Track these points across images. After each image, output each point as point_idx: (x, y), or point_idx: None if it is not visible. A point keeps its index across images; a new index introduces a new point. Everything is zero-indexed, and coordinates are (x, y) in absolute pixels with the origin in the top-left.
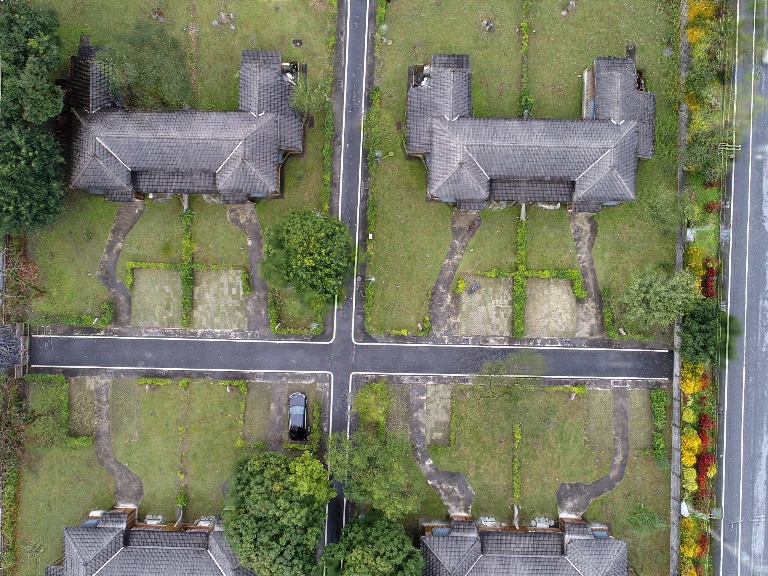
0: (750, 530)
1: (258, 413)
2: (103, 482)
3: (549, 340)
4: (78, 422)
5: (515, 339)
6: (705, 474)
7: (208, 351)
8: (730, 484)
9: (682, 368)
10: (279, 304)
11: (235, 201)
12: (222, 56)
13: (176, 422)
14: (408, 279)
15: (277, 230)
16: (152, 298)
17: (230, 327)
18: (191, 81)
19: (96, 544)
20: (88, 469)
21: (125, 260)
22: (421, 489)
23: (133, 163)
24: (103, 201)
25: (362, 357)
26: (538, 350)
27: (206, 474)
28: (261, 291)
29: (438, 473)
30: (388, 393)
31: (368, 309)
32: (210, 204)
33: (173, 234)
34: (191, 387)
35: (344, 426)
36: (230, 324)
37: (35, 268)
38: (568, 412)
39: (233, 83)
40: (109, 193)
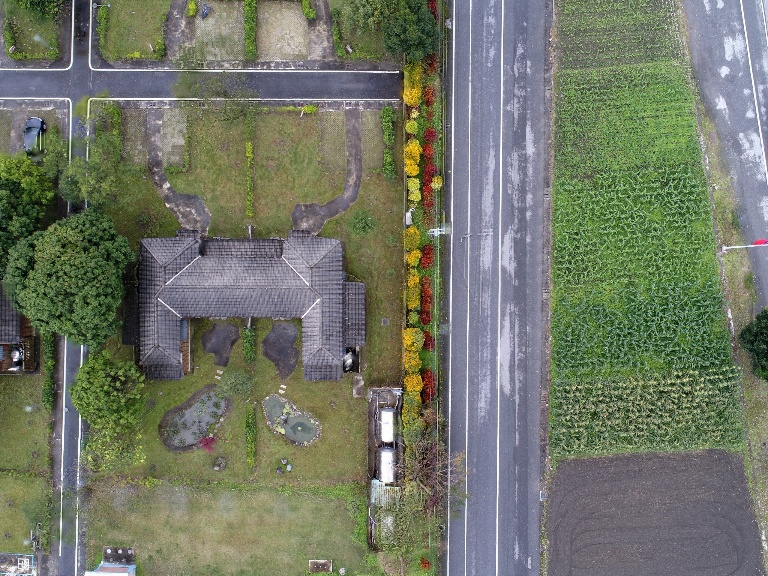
0: (478, 244)
1: None
2: None
3: (282, 63)
4: None
5: (248, 62)
6: (430, 186)
7: None
8: (458, 199)
9: (413, 88)
10: (17, 32)
11: None
12: None
13: None
14: (143, 5)
15: None
16: None
17: None
18: None
19: None
20: None
21: None
22: (159, 212)
23: None
24: None
25: (99, 83)
26: (272, 73)
27: None
28: None
29: (176, 196)
30: (125, 118)
31: (101, 32)
32: None
33: None
34: None
35: (83, 152)
36: None
37: None
38: (302, 134)
39: None
40: None
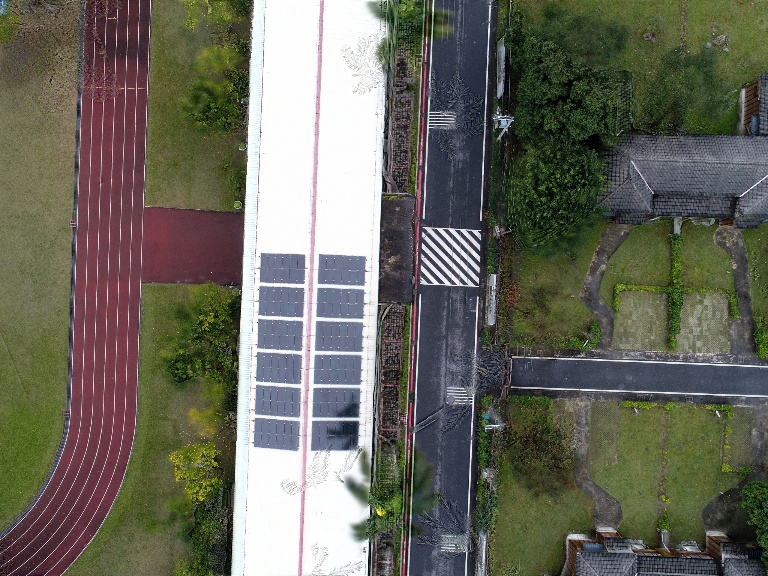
0: None
1: (739, 438)
2: (581, 505)
3: None
4: (557, 444)
5: None
6: None
7: (690, 375)
8: None
9: None
10: None
11: (748, 225)
12: (712, 78)
13: (656, 446)
14: None
15: (763, 254)
16: (635, 321)
17: (712, 351)
18: (680, 103)
19: (616, 570)
20: (566, 492)
21: (609, 282)
22: None
23: (659, 186)
24: (604, 223)
25: None
26: None
27: (686, 499)
28: (745, 315)
29: None
30: None
31: None
32: (697, 227)
33: (658, 256)
34: (672, 411)
35: None
36: (712, 348)
37: (518, 289)
38: None
39: (722, 105)
40: (621, 216)
